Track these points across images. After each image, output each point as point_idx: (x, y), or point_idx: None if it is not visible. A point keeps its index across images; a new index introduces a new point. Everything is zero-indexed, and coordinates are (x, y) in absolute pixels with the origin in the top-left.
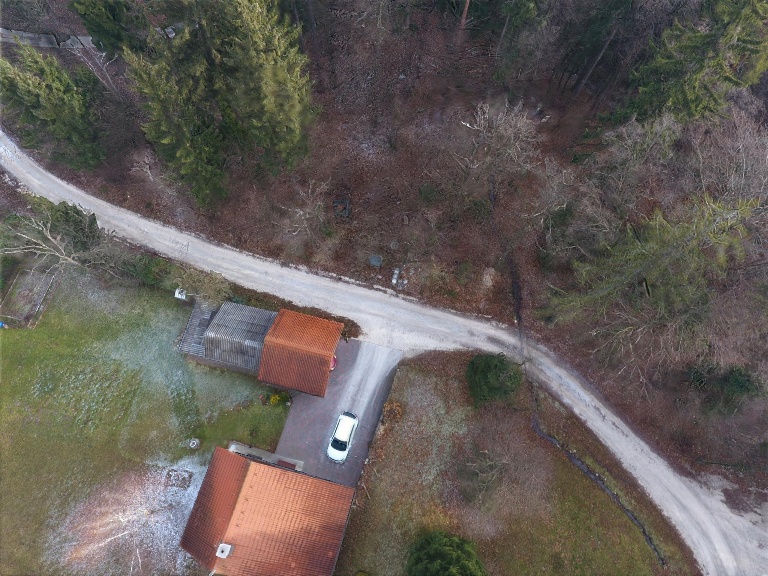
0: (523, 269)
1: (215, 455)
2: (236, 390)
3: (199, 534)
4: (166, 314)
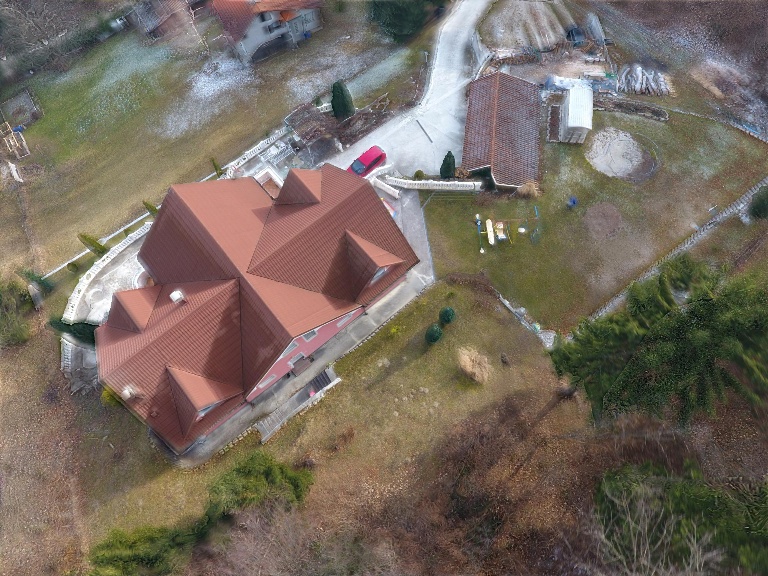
0: None
1: (216, 4)
2: (203, 27)
3: (241, 22)
4: (123, 43)
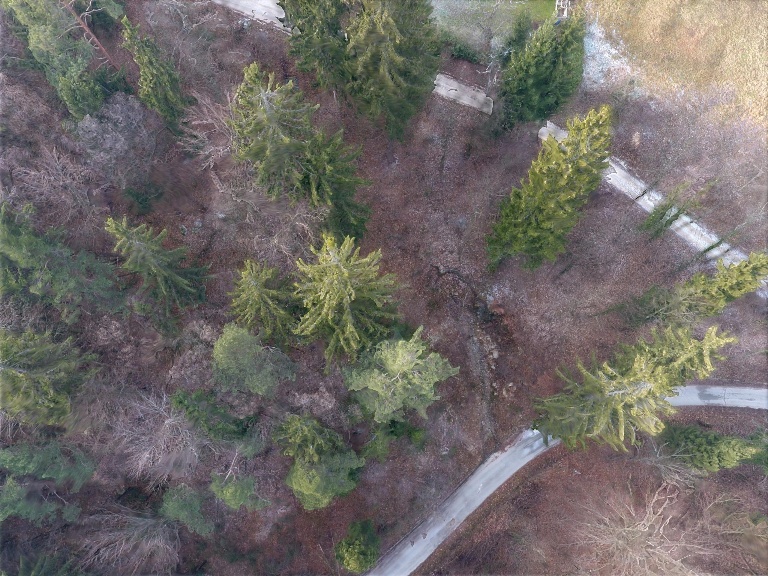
0: (142, 18)
1: None
2: None
3: None
4: None
